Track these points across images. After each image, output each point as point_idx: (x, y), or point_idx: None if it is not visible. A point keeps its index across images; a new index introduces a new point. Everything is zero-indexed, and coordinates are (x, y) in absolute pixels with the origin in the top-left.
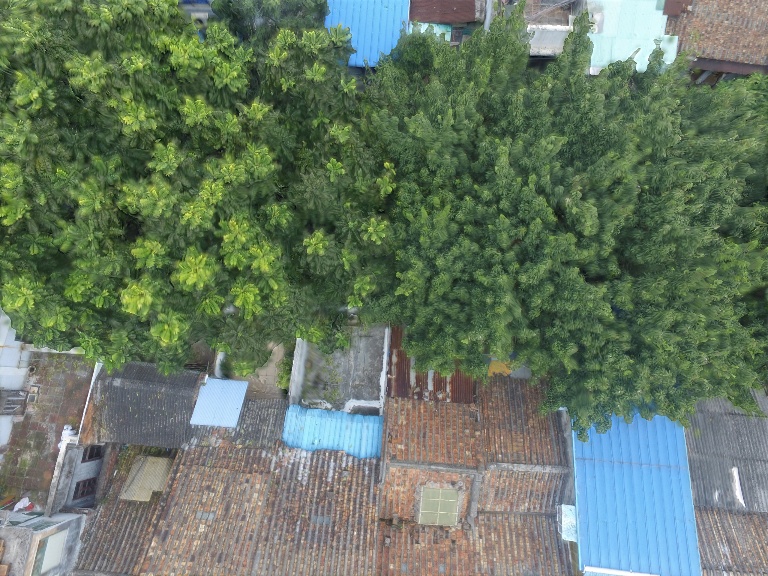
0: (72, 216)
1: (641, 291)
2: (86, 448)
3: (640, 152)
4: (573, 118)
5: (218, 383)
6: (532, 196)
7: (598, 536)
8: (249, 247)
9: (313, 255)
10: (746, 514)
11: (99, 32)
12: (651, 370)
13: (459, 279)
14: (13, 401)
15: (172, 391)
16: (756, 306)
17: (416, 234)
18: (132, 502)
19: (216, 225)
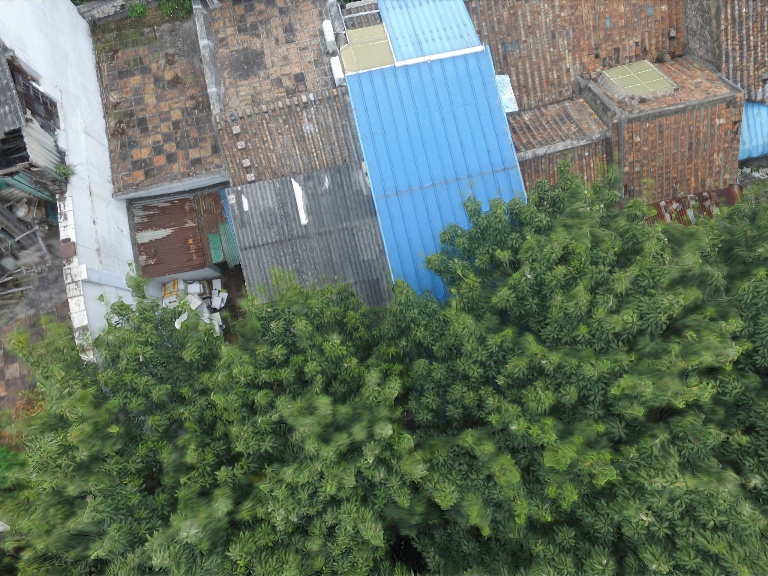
0: None
1: None
2: None
3: None
4: None
5: None
6: None
7: (473, 87)
8: None
9: None
10: None
11: None
12: None
13: None
14: None
15: None
16: None
17: None
18: None
19: None
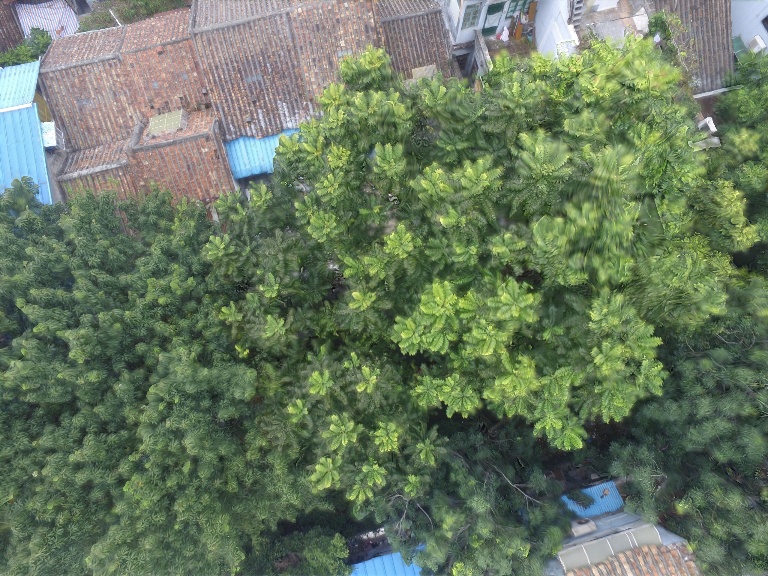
0: None
1: None
2: None
3: None
4: None
5: None
6: None
7: (23, 130)
8: (301, 144)
9: None
10: None
11: None
12: None
13: None
14: None
15: None
16: None
17: None
18: None
19: None
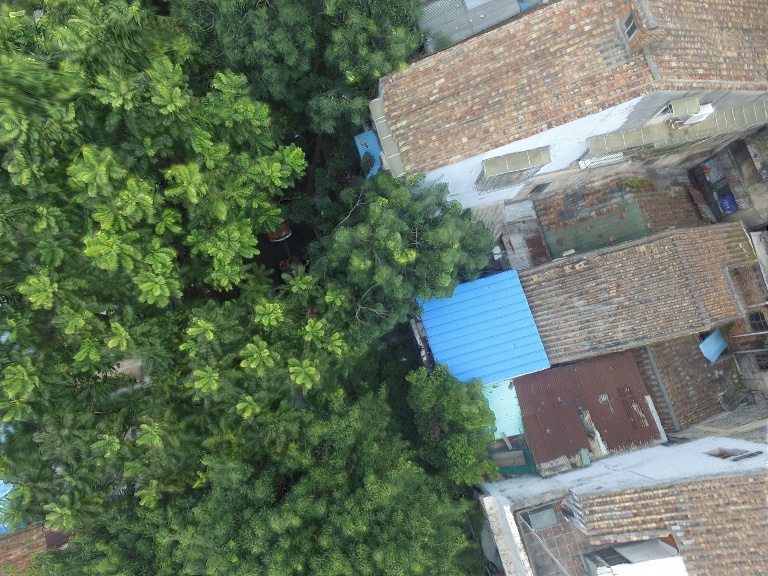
0: None
1: None
2: None
3: None
4: None
5: None
6: None
7: None
8: None
9: None
10: None
11: (10, 175)
12: None
13: None
14: None
15: None
16: None
17: None
18: None
19: None
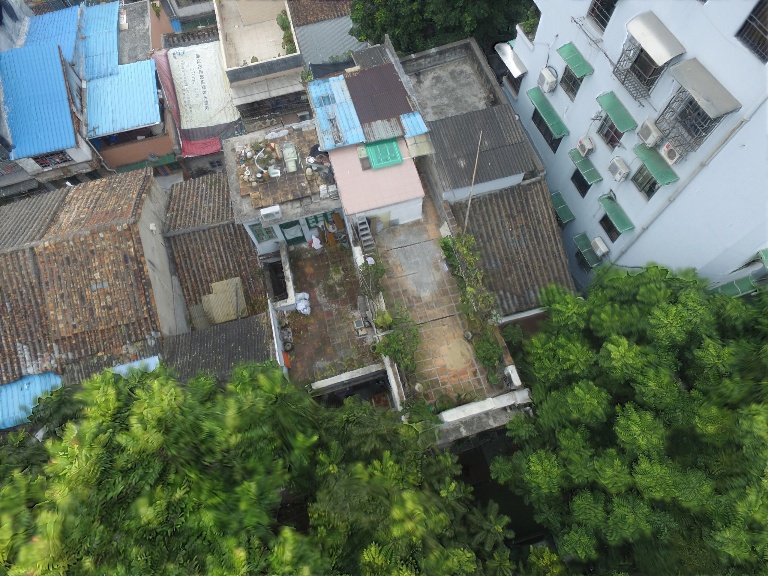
0: None
1: None
2: None
3: None
4: None
5: None
6: None
7: None
8: None
9: None
10: None
11: None
12: None
13: None
14: None
15: (193, 380)
16: None
17: None
18: None
19: None
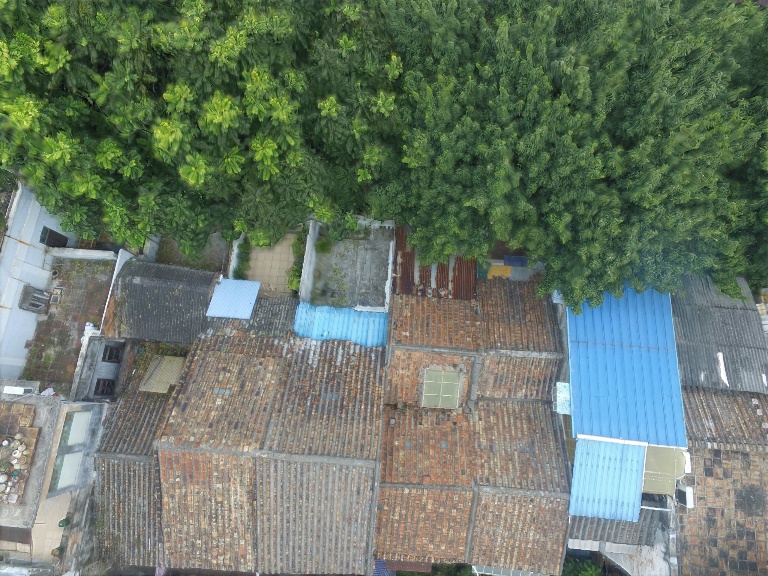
0: (108, 69)
1: (630, 157)
2: (106, 348)
3: (630, 29)
4: (568, 5)
5: (232, 282)
6: (530, 69)
7: (590, 408)
8: (270, 98)
9: (327, 118)
10: (730, 396)
11: None
12: (639, 235)
13: (461, 163)
14: (38, 298)
15: (189, 288)
16: (739, 188)
17: (421, 120)
18: (150, 396)
19: (240, 74)
